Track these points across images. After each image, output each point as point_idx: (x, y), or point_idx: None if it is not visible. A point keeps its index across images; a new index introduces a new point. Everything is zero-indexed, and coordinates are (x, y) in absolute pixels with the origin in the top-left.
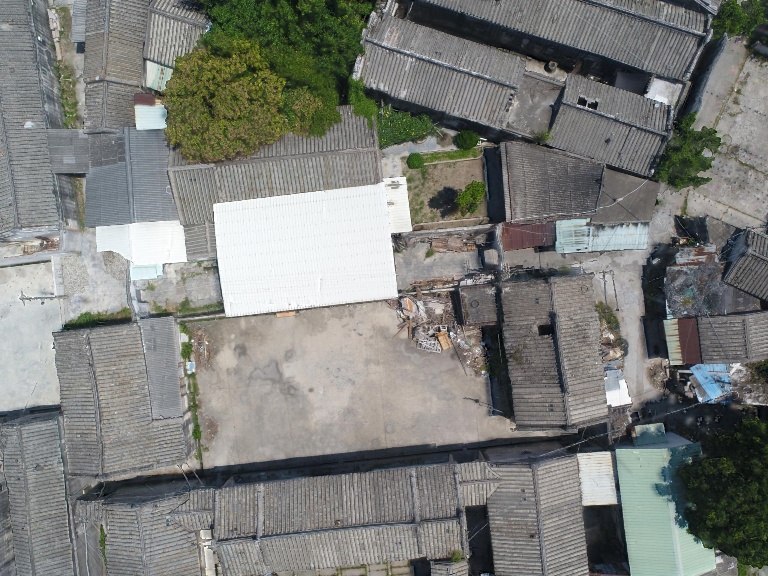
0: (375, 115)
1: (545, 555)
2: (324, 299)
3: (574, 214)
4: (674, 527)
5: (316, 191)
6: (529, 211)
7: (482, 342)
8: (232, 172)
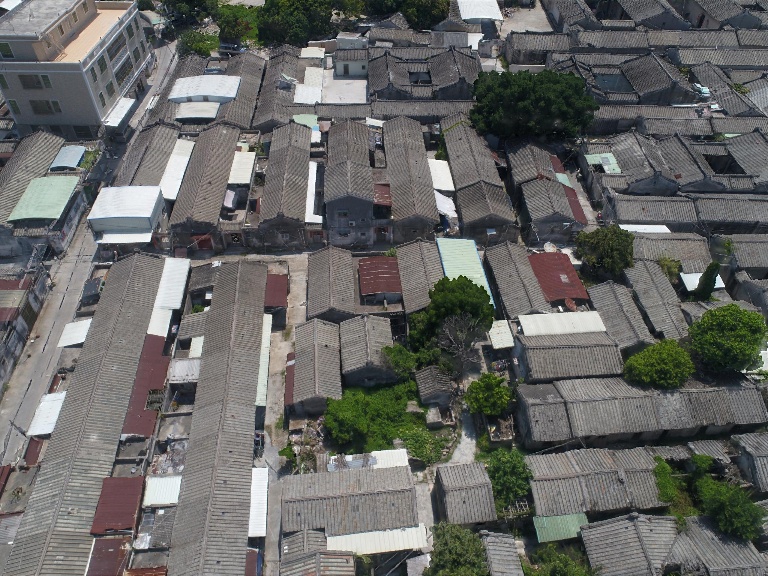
0: None
1: None
2: (497, 7)
3: None
4: None
5: (458, 6)
6: None
7: None
8: None
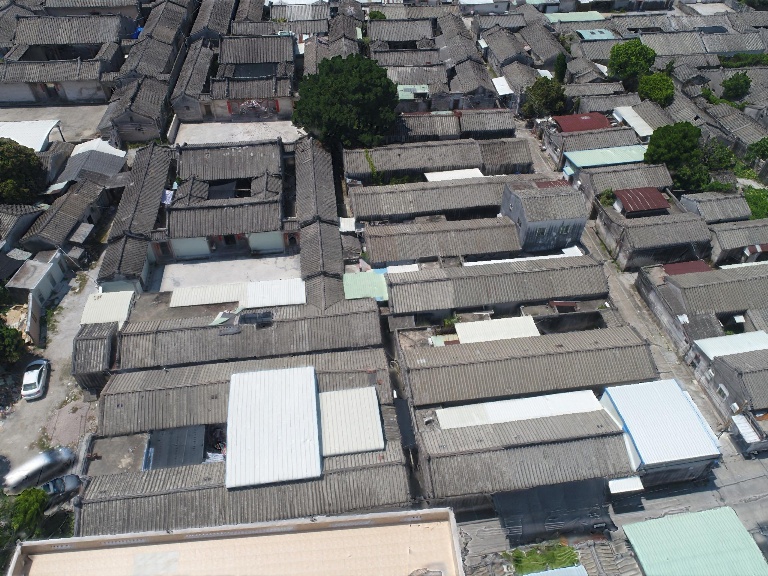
0: None
1: None
2: (5, 123)
3: None
4: None
5: None
6: None
7: None
8: None
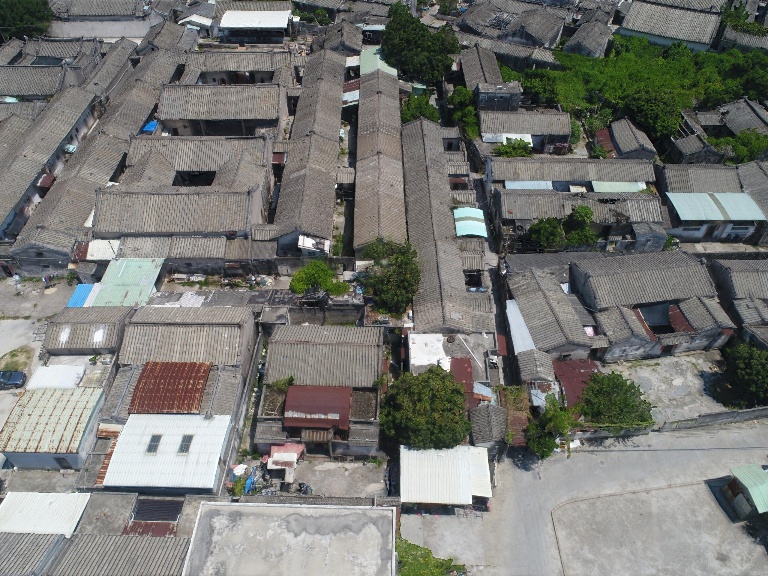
0: (293, 7)
1: (324, 65)
2: None
3: None
4: (378, 59)
5: None
6: None
7: None
8: (237, 4)
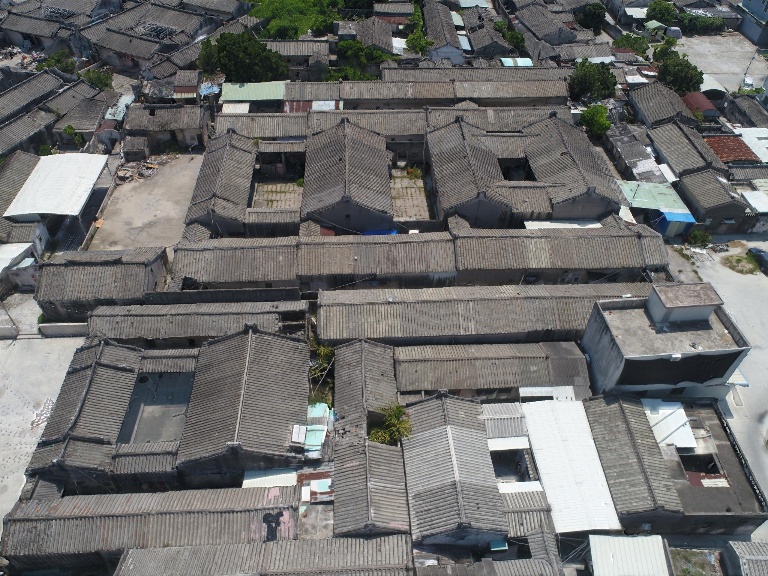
0: None
1: None
2: (92, 179)
3: (103, 108)
4: (259, 83)
5: (27, 179)
6: (94, 123)
7: (161, 156)
8: None
